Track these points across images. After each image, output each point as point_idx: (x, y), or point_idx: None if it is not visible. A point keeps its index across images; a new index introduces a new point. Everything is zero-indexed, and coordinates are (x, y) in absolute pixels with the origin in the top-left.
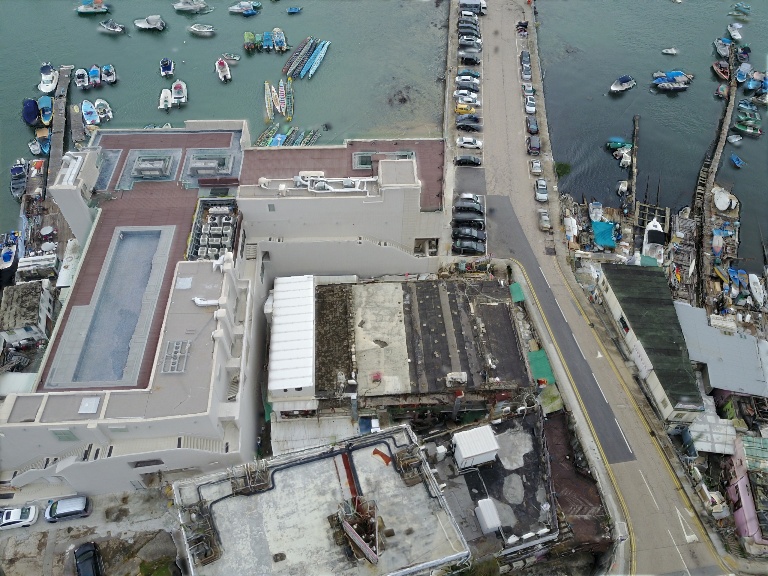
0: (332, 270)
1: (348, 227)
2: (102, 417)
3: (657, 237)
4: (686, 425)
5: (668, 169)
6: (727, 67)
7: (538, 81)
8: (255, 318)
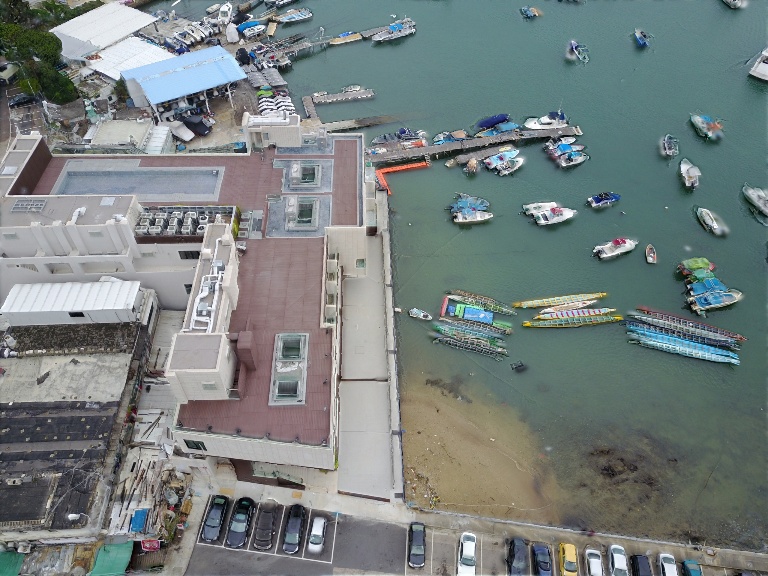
0: None
1: None
2: None
3: None
4: None
5: None
6: None
7: None
8: None
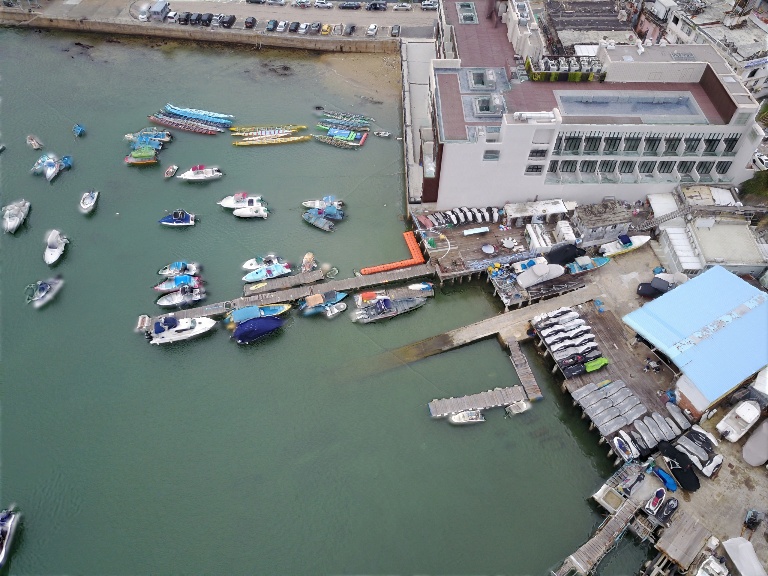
0: None
1: None
2: (733, 74)
3: None
4: None
5: None
6: None
7: None
8: None
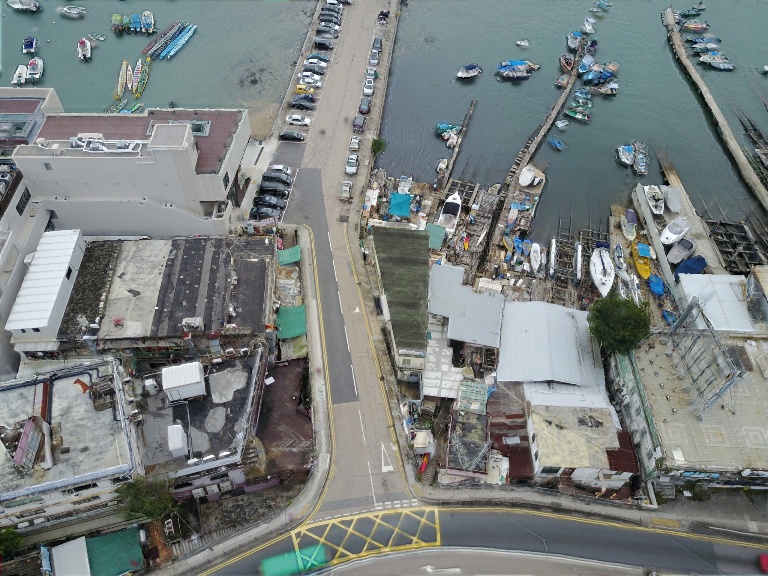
0: (123, 230)
1: (130, 188)
2: None
3: (451, 208)
4: (418, 372)
5: (492, 150)
6: (571, 58)
7: (384, 66)
8: (18, 268)
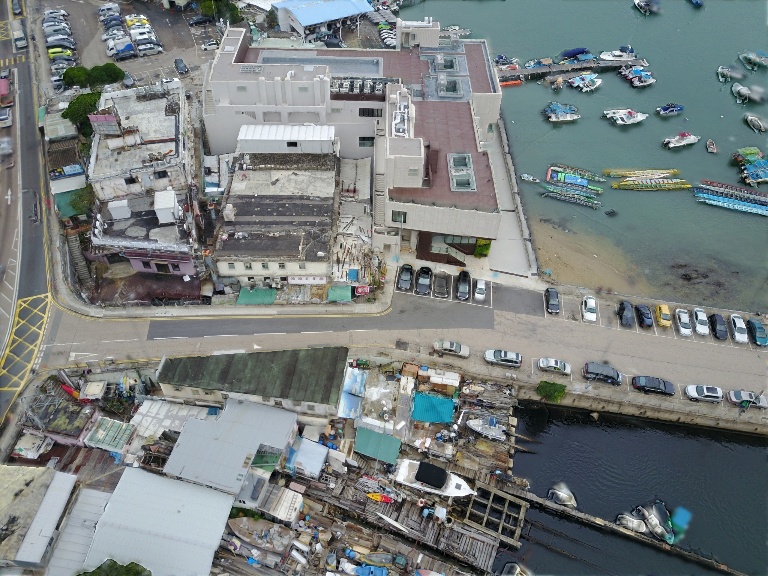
0: None
1: None
2: (220, 53)
3: (430, 472)
4: None
5: None
6: None
7: None
8: None
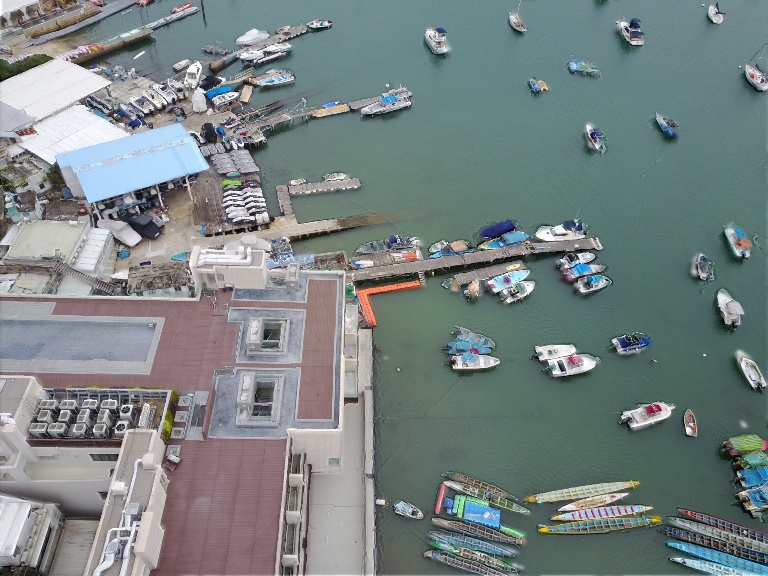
0: None
1: None
2: None
3: None
4: None
5: None
6: None
7: None
8: None
